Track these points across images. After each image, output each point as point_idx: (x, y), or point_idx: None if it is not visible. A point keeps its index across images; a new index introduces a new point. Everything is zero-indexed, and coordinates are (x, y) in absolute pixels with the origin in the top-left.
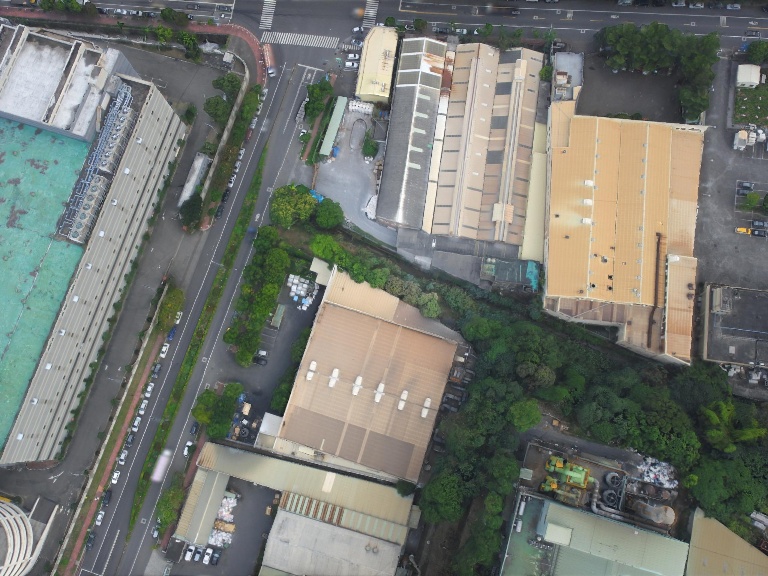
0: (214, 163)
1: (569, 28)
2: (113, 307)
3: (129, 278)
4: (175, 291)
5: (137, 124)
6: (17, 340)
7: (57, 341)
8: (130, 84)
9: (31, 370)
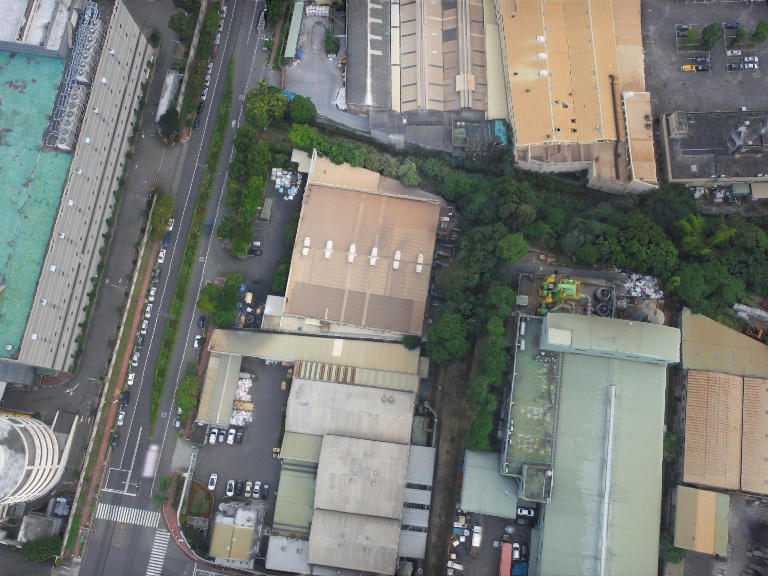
0: (185, 79)
1: None
2: (106, 223)
3: (118, 194)
4: (164, 197)
5: (108, 34)
6: (19, 248)
7: (58, 244)
8: (95, 1)
9: (36, 273)
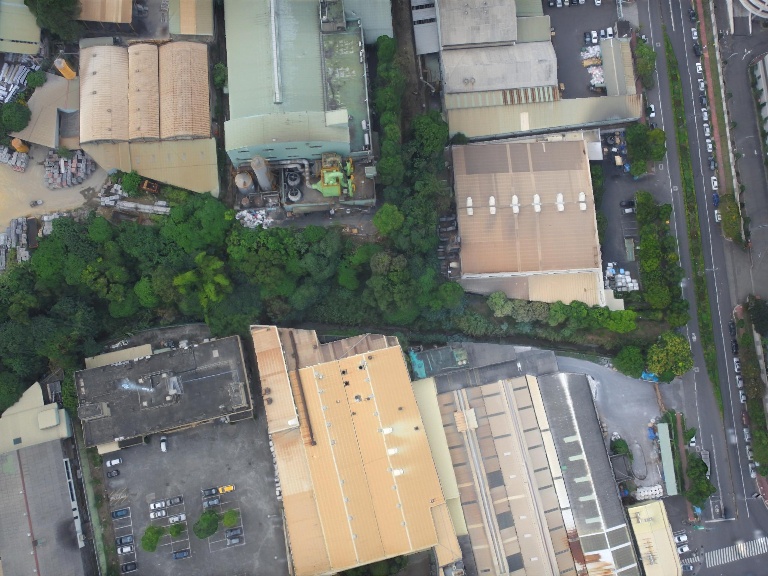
0: (764, 374)
1: None
2: None
3: None
4: None
5: None
6: None
7: None
8: None
9: None
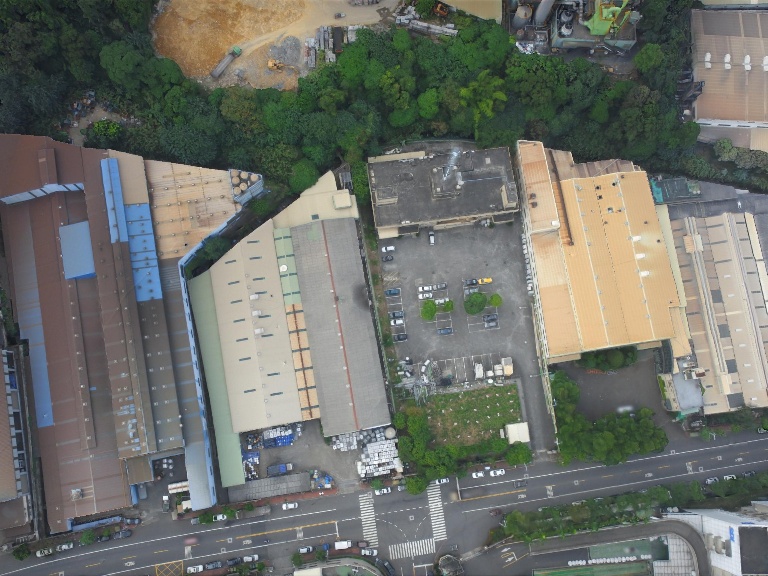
0: None
1: (686, 453)
2: None
3: None
4: None
5: None
6: None
7: None
8: None
9: None
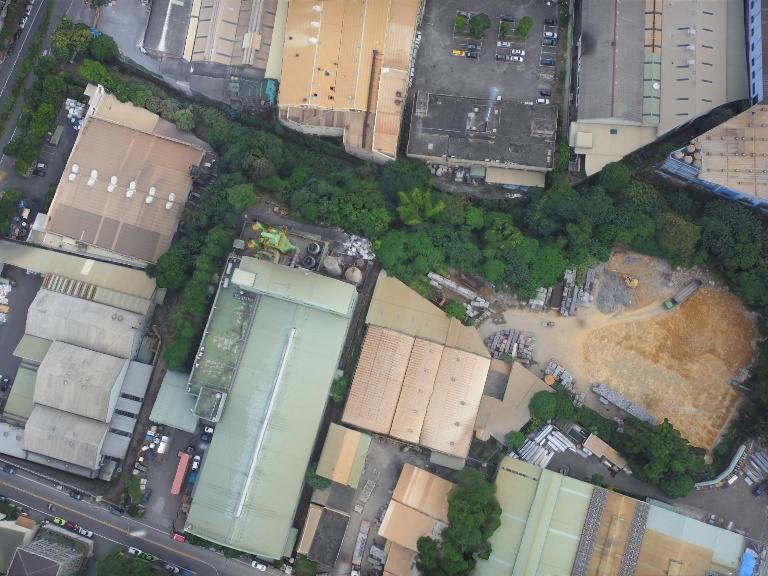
0: None
1: None
2: None
3: None
4: None
5: None
6: None
7: None
8: None
9: None
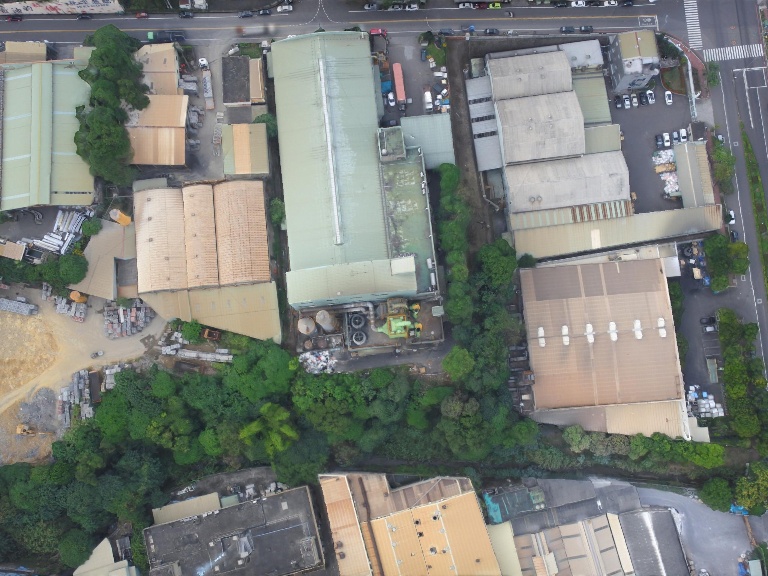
0: None
1: None
2: None
3: None
4: None
5: None
6: None
7: None
8: None
9: None
